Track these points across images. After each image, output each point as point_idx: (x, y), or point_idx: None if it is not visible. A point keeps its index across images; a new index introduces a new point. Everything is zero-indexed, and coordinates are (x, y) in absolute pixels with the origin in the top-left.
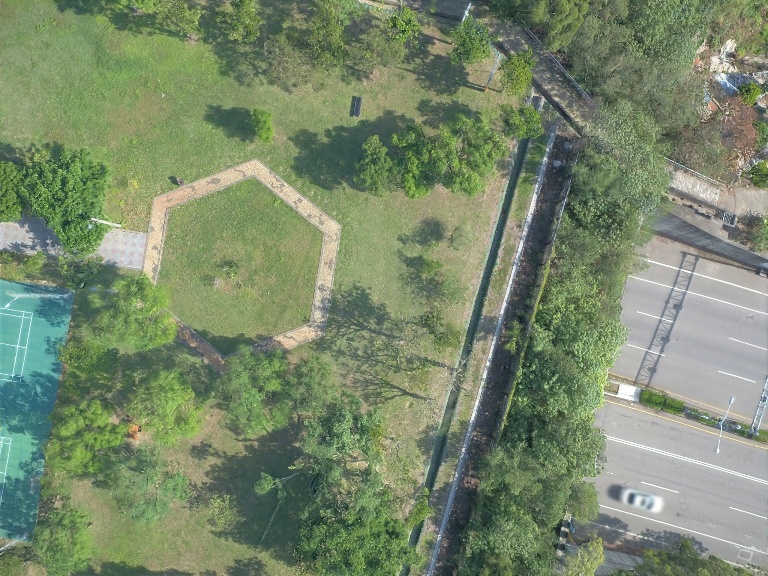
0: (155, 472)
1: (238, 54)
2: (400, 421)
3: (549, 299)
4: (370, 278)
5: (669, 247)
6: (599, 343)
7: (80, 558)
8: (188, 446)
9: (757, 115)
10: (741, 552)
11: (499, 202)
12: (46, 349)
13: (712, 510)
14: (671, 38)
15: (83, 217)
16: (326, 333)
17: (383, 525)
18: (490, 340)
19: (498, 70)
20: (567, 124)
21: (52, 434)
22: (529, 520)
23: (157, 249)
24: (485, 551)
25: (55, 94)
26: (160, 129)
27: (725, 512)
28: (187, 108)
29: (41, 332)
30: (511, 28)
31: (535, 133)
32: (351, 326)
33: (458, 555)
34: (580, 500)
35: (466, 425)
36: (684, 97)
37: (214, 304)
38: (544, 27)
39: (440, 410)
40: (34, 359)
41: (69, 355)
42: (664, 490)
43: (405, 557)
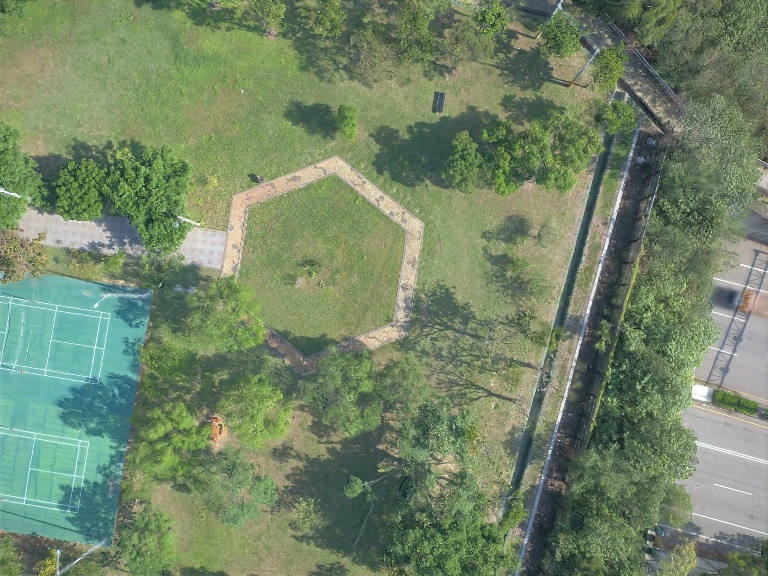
0: (239, 475)
1: (318, 49)
2: (485, 423)
3: (639, 298)
4: (454, 277)
5: (741, 245)
6: (692, 342)
7: None
8: (269, 449)
9: None
10: None
11: (584, 199)
12: (124, 350)
13: None
14: (760, 32)
15: (167, 215)
16: (409, 333)
17: (479, 529)
18: (576, 340)
19: (582, 65)
20: (649, 120)
21: (130, 437)
22: (623, 523)
23: (237, 248)
24: (575, 555)
25: (132, 90)
26: (239, 126)
27: None
28: (266, 104)
29: (119, 333)
30: (594, 22)
31: (628, 128)
32: (435, 326)
33: (547, 559)
34: (674, 503)
35: (552, 426)
36: None
37: (295, 304)
38: (630, 21)
39: (525, 411)
40: (112, 360)
41: (149, 356)
42: (737, 492)
43: (502, 562)
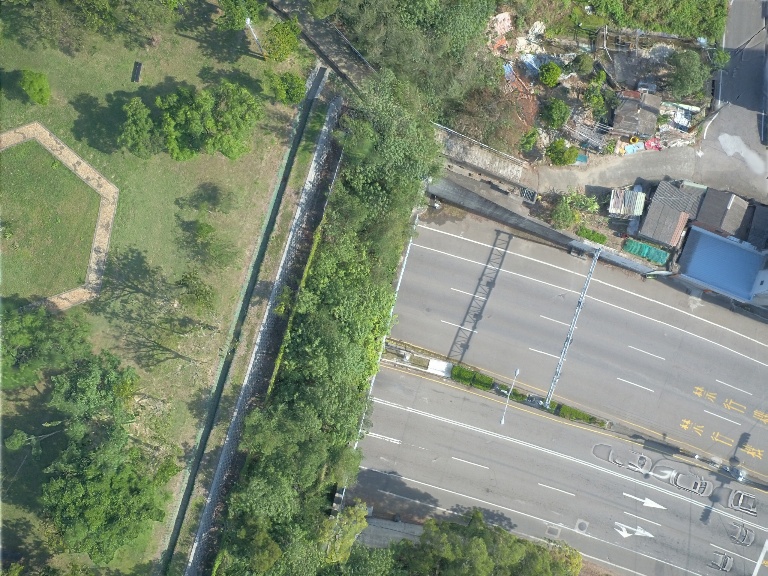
0: None
1: (22, 18)
2: (172, 384)
3: (318, 264)
4: (146, 241)
5: (483, 225)
6: (361, 308)
7: None
8: None
9: (561, 95)
10: (549, 528)
11: (278, 169)
12: None
13: (521, 486)
14: (447, 12)
15: None
16: (100, 295)
17: (126, 481)
18: (265, 305)
19: None
20: (356, 96)
21: None
22: (284, 481)
23: None
24: (247, 513)
25: None
26: None
27: (534, 488)
28: None
29: None
30: None
31: (297, 99)
32: (126, 288)
33: (221, 517)
34: None
35: (239, 389)
36: (461, 70)
37: None
38: None
39: (213, 374)
40: None
41: None
42: (474, 466)
43: (146, 513)
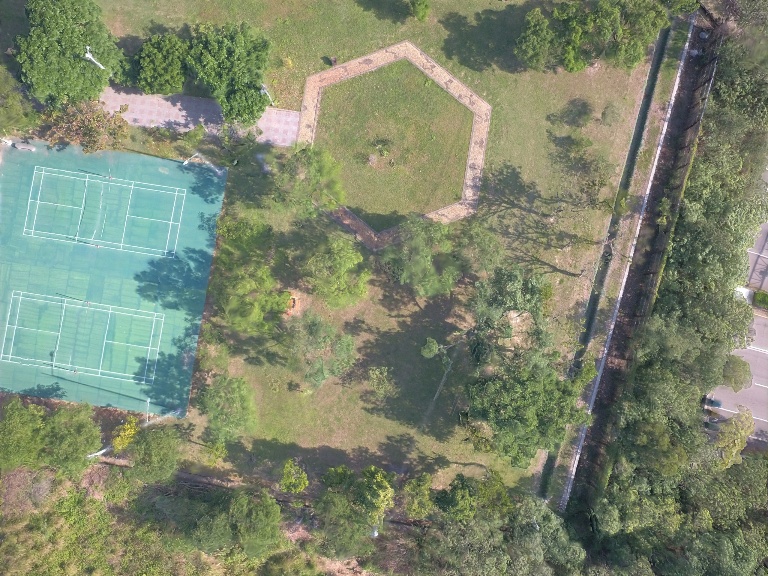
0: (316, 342)
1: None
2: (551, 297)
3: (698, 175)
4: (520, 157)
5: None
6: (750, 215)
7: None
8: (341, 322)
9: None
10: None
11: (643, 86)
12: (200, 225)
13: None
14: None
15: (249, 86)
16: (477, 211)
17: (555, 384)
18: (637, 219)
19: None
20: None
21: (205, 310)
22: (688, 386)
23: (310, 127)
24: (640, 421)
25: None
26: (312, 10)
27: None
28: None
29: (194, 208)
30: None
31: (690, 8)
32: (502, 204)
33: (612, 427)
34: (735, 368)
35: (614, 302)
36: None
37: (367, 182)
38: None
39: (589, 288)
40: (187, 235)
41: (227, 228)
42: None
43: (577, 415)
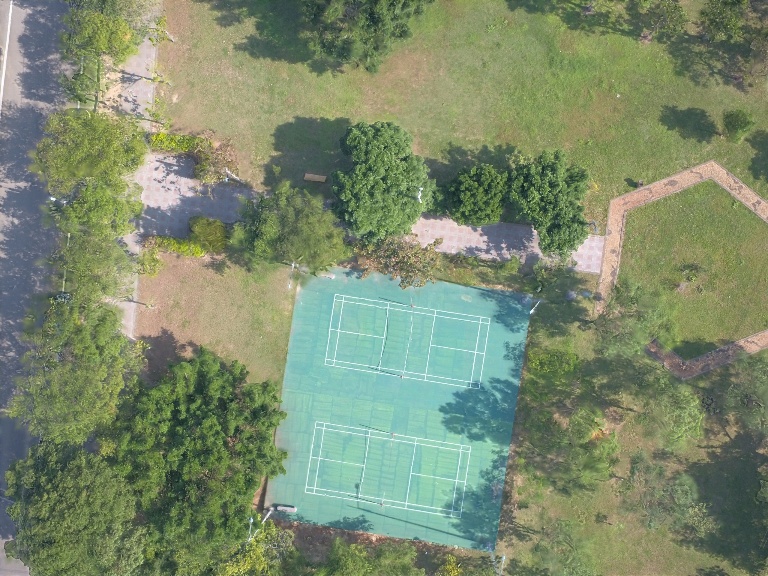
0: (637, 480)
1: (693, 53)
2: None
3: None
4: None
5: None
6: None
7: (538, 568)
8: (649, 453)
9: None
10: None
11: None
12: (505, 355)
13: None
14: None
15: (573, 220)
16: None
17: None
18: None
19: None
20: None
21: (511, 442)
22: None
23: (615, 253)
24: None
25: (507, 95)
26: (615, 130)
27: None
28: (642, 109)
29: (499, 338)
30: None
31: None
32: None
33: None
34: None
35: None
36: None
37: (674, 308)
38: None
39: None
40: (493, 365)
41: (539, 361)
42: None
43: None
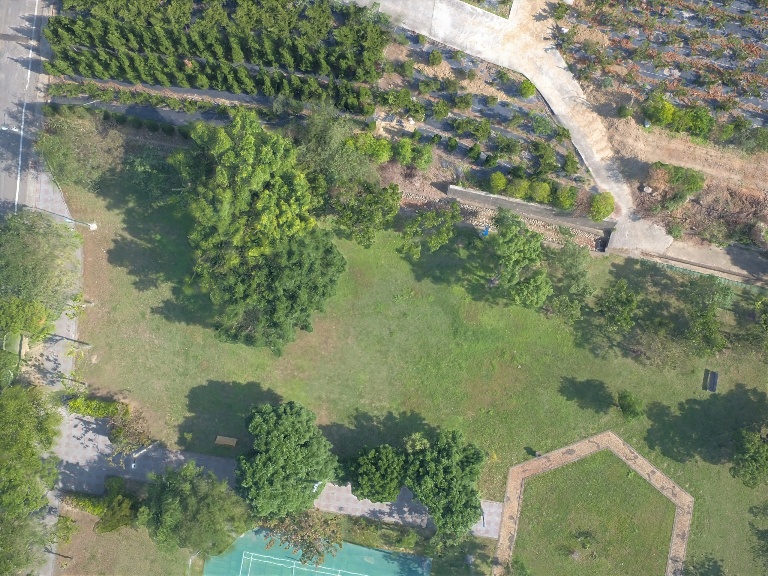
0: None
1: (593, 326)
2: None
3: None
4: (722, 550)
5: None
6: None
7: None
8: None
9: None
10: None
11: None
12: None
13: None
14: None
15: (465, 506)
16: None
17: None
18: None
19: None
20: None
21: None
22: None
23: (513, 519)
24: None
25: (413, 363)
26: (516, 400)
27: None
28: (543, 379)
29: None
30: None
31: None
32: None
33: None
34: None
35: None
36: None
37: (569, 574)
38: None
39: None
40: None
41: None
42: None
43: None
